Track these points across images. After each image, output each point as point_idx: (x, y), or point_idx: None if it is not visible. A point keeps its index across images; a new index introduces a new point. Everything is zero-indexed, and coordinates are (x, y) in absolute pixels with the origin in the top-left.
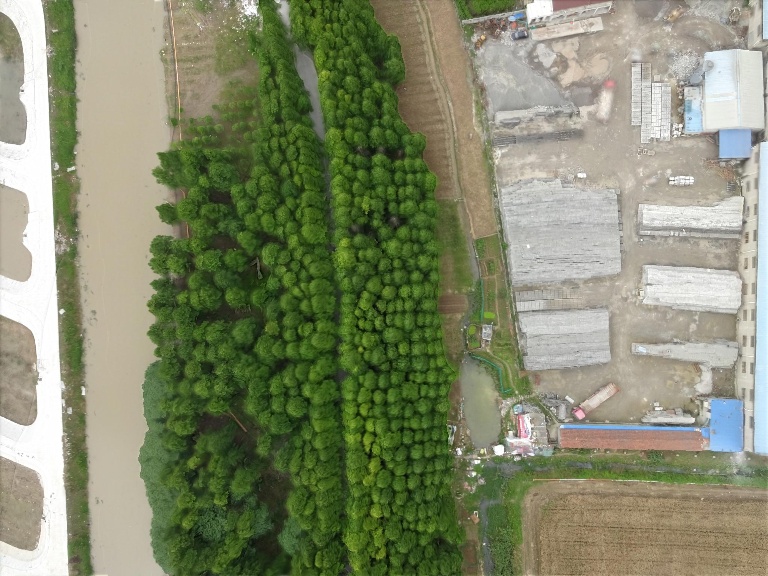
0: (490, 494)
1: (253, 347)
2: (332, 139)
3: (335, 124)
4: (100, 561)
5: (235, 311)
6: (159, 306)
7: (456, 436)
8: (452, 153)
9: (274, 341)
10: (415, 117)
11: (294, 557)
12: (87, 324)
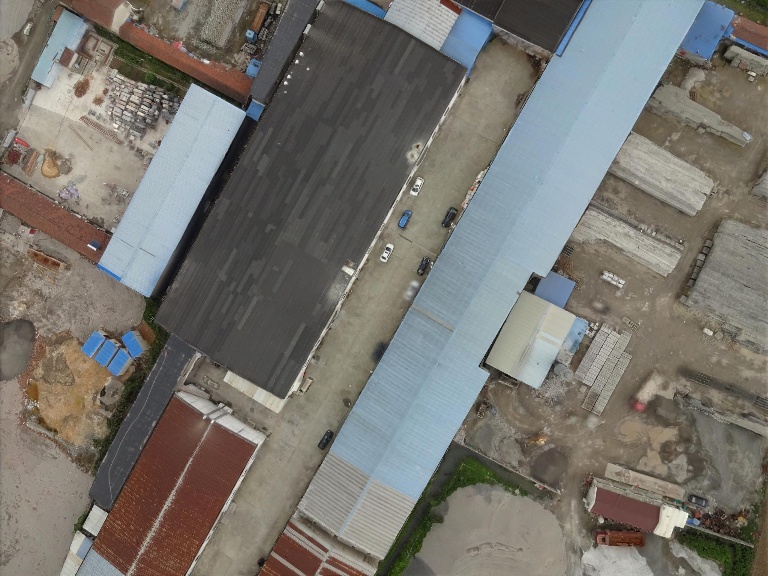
0: None
1: None
2: None
3: None
4: None
5: None
6: None
7: None
8: None
9: None
10: None
11: None
12: None
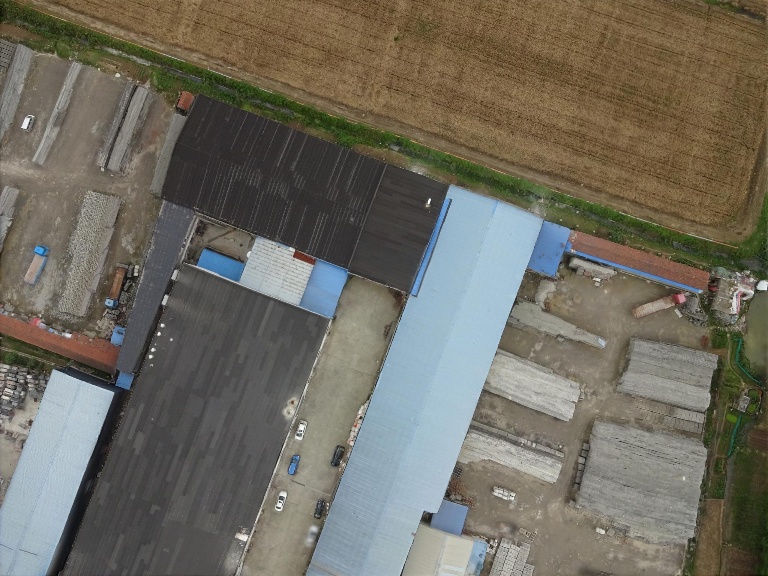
0: None
1: None
2: None
3: None
4: None
5: None
6: None
7: None
8: None
9: None
10: None
11: None
12: None
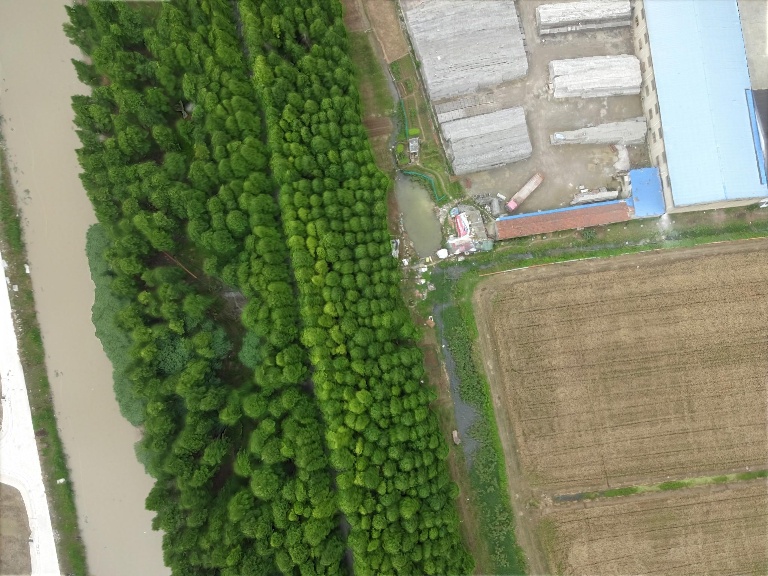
0: (441, 298)
1: (187, 176)
2: None
3: None
4: (68, 432)
5: (165, 152)
6: (88, 154)
7: (400, 248)
8: None
9: (205, 162)
10: None
11: (257, 368)
12: (22, 204)
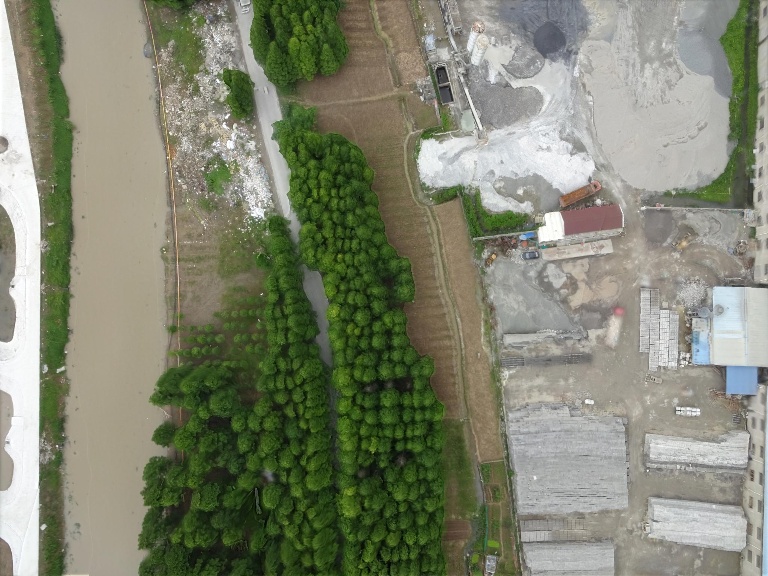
0: None
1: None
2: (341, 383)
3: (344, 364)
4: None
5: (231, 547)
6: (151, 546)
7: None
8: (459, 370)
9: None
10: (423, 331)
11: None
12: (70, 538)
